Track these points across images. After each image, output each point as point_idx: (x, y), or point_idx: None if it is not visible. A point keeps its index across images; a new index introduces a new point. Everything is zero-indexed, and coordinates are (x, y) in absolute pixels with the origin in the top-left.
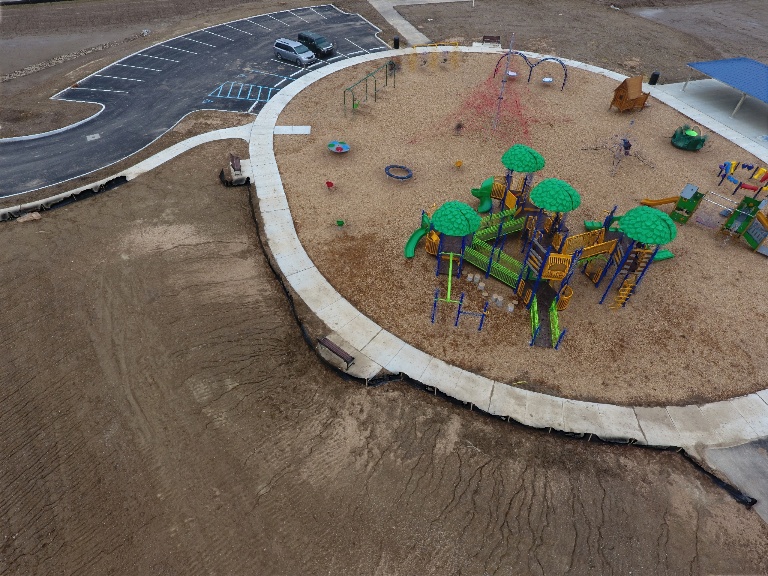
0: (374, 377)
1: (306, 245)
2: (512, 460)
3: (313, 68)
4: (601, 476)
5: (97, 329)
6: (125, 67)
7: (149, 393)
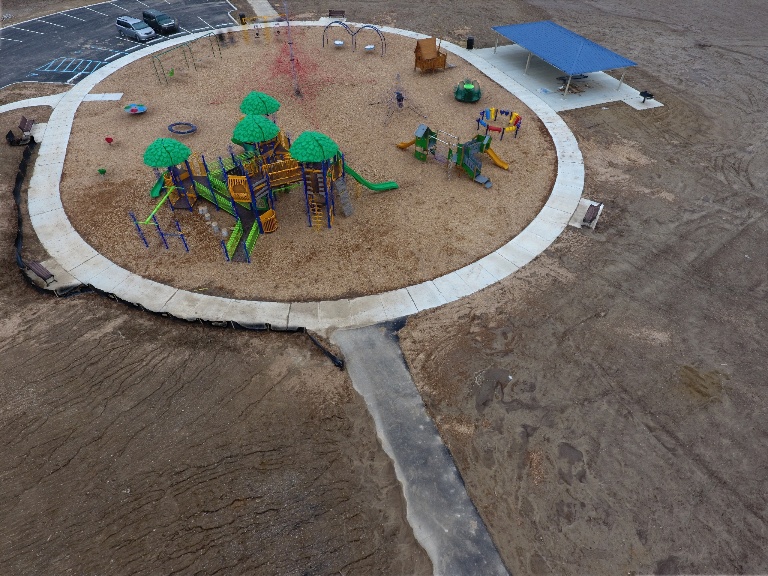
0: (70, 291)
1: (64, 191)
2: (149, 343)
3: (151, 43)
4: (220, 351)
5: None
6: None
7: None
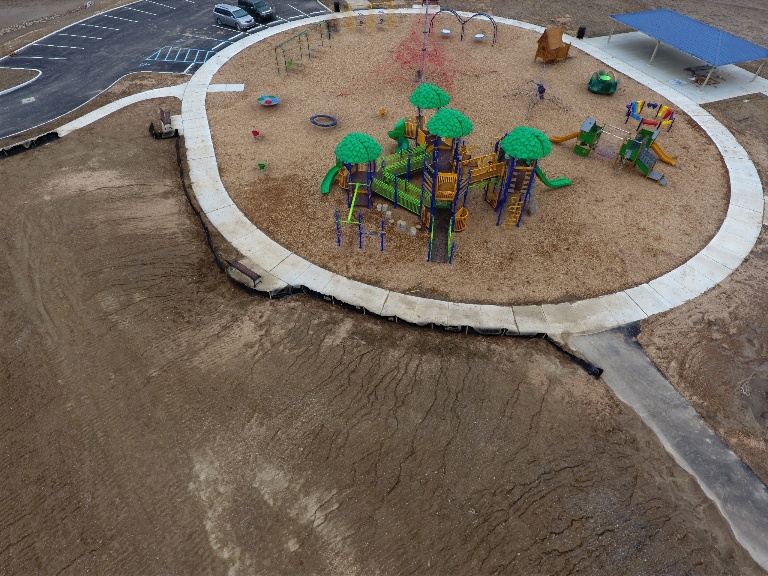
0: (279, 292)
1: (228, 186)
2: (392, 349)
3: (252, 32)
4: (470, 358)
5: (15, 257)
6: (64, 36)
7: (59, 305)
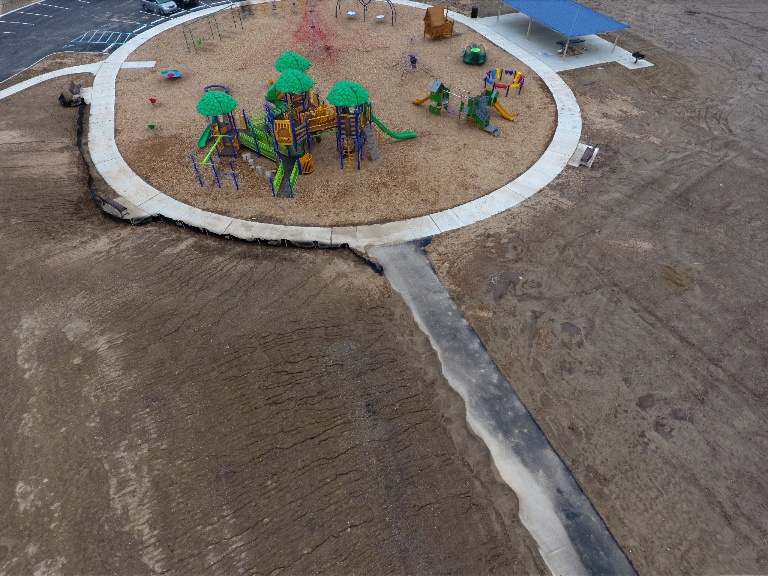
0: (142, 221)
1: (119, 143)
2: (219, 256)
3: (175, 16)
4: (279, 261)
5: None
6: (0, 23)
7: None
